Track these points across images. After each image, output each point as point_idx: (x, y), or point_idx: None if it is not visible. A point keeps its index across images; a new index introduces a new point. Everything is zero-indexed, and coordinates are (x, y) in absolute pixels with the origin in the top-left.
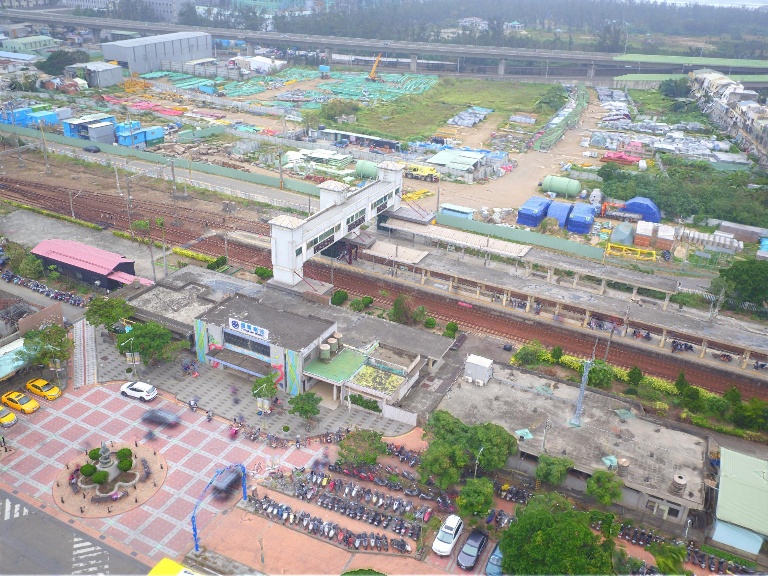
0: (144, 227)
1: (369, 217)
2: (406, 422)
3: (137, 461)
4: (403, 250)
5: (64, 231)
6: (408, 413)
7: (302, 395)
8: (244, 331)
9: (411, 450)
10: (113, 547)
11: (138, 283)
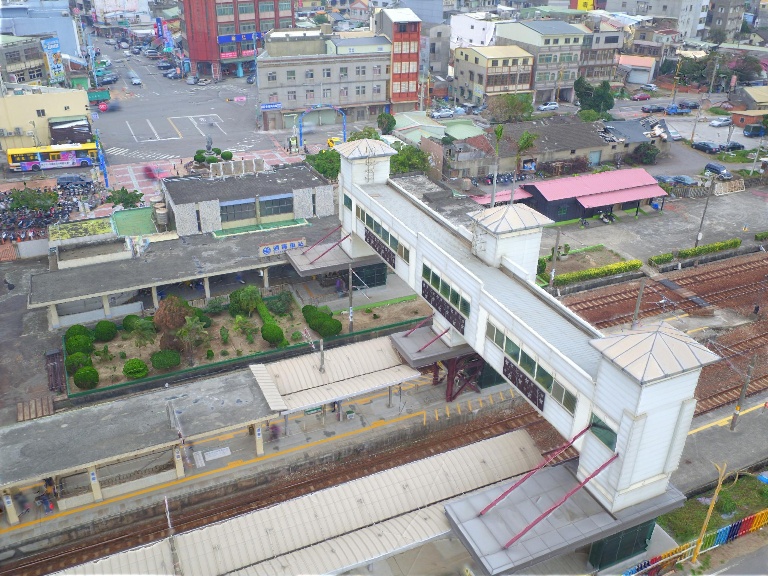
0: (521, 140)
1: (481, 346)
2: (30, 254)
3: (209, 171)
4: (335, 388)
5: (760, 220)
6: (25, 242)
7: (133, 193)
8: (244, 171)
9: (0, 238)
10: (154, 161)
11: (464, 183)
